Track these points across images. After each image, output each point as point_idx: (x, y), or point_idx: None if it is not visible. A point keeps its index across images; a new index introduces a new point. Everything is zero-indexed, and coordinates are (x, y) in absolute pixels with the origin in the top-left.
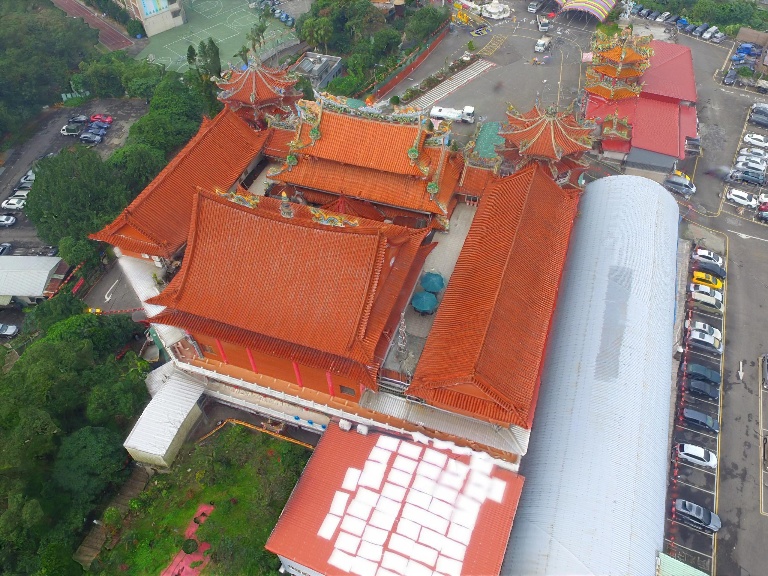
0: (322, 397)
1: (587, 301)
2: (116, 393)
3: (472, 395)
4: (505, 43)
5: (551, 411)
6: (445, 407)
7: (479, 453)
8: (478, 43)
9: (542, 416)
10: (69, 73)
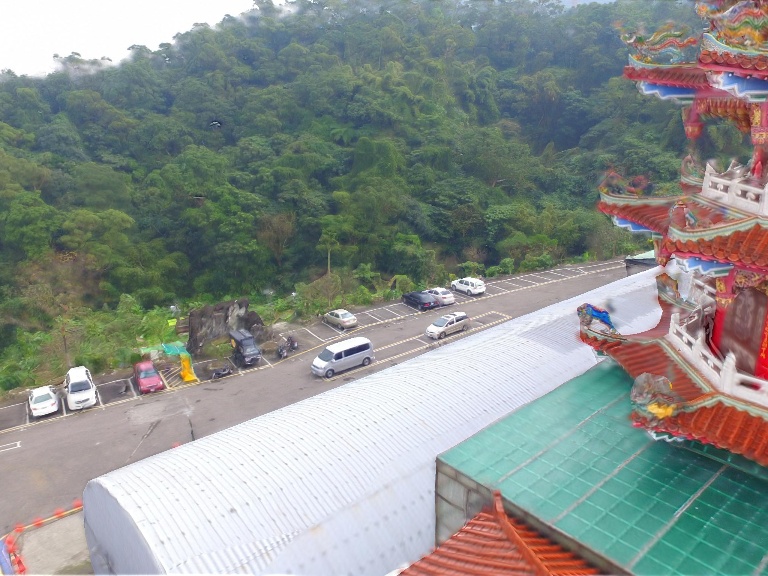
0: None
1: None
2: None
3: None
4: None
5: None
6: None
7: None
8: None
9: None
10: None
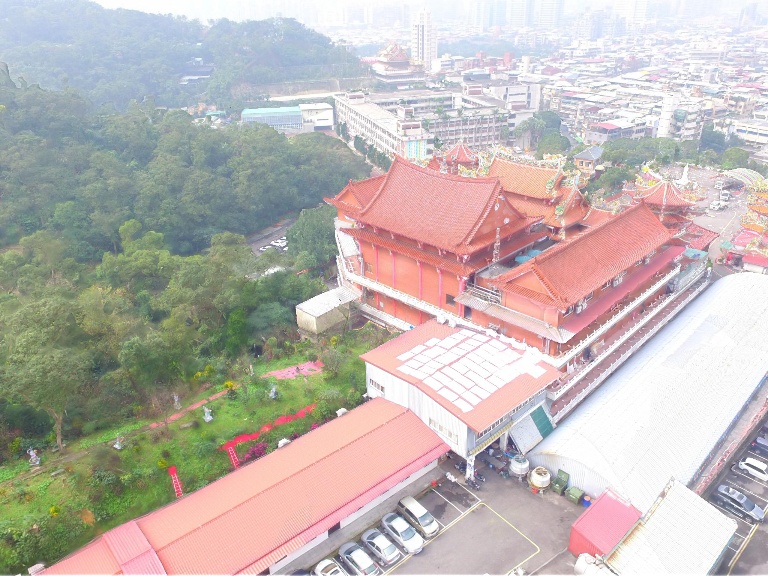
0: None
1: (678, 330)
2: (303, 285)
3: (533, 289)
4: None
5: (614, 379)
6: (514, 308)
7: (532, 348)
8: None
9: (606, 383)
10: (344, 186)
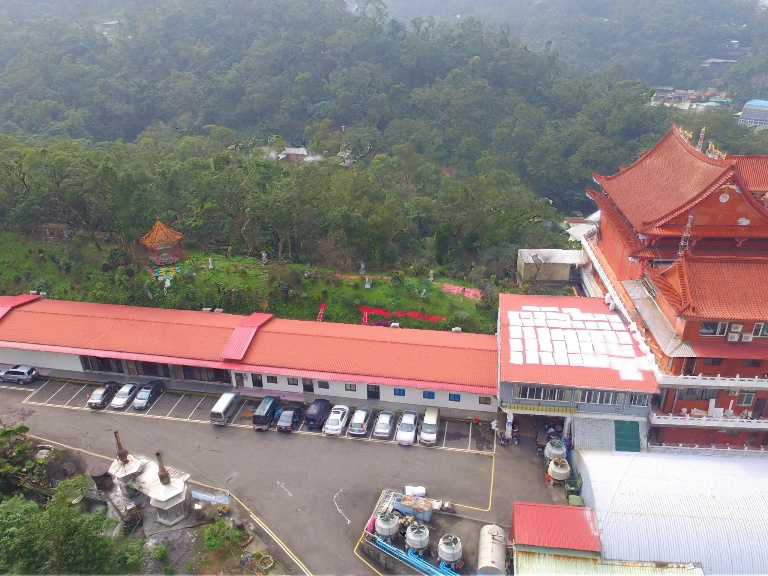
0: (620, 289)
1: None
2: None
3: (676, 289)
4: None
5: None
6: (662, 307)
7: (651, 353)
8: None
9: None
10: None
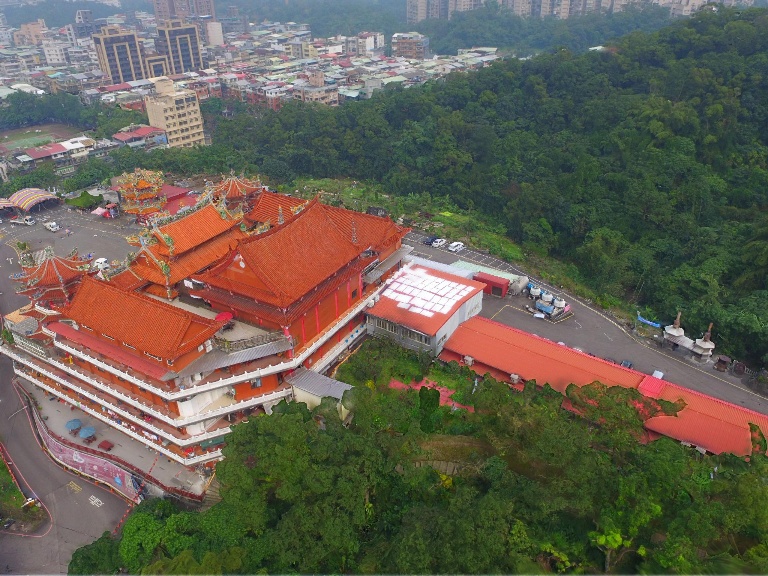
0: None
1: None
2: None
3: None
4: (24, 241)
5: None
6: (385, 258)
7: (404, 267)
8: (5, 252)
9: None
10: None
